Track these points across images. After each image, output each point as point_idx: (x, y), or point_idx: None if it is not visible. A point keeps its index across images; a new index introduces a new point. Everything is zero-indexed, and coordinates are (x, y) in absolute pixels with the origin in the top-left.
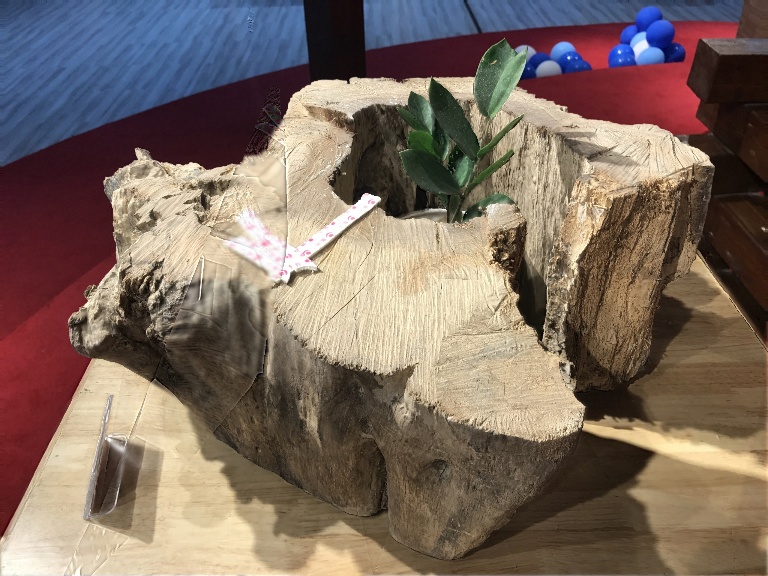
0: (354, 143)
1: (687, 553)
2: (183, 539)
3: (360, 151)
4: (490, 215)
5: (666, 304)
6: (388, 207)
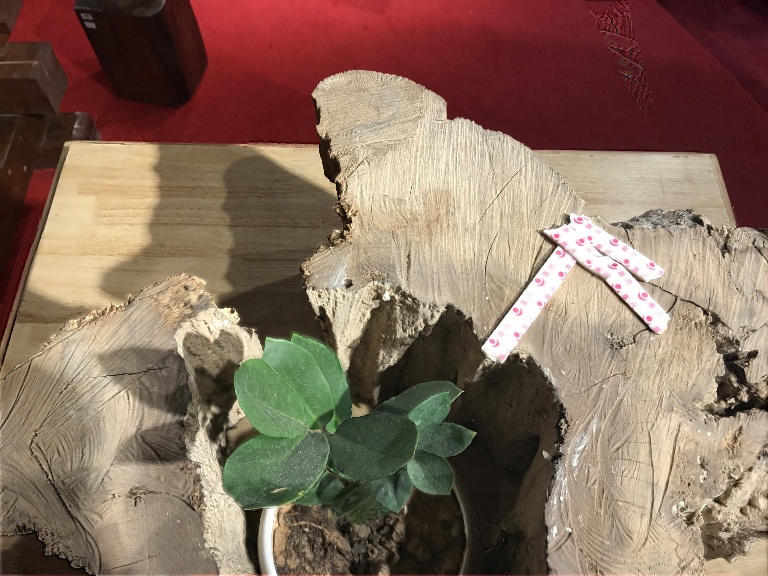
0: (545, 574)
1: (212, 240)
2: None
3: None
4: (344, 266)
5: (42, 561)
6: None
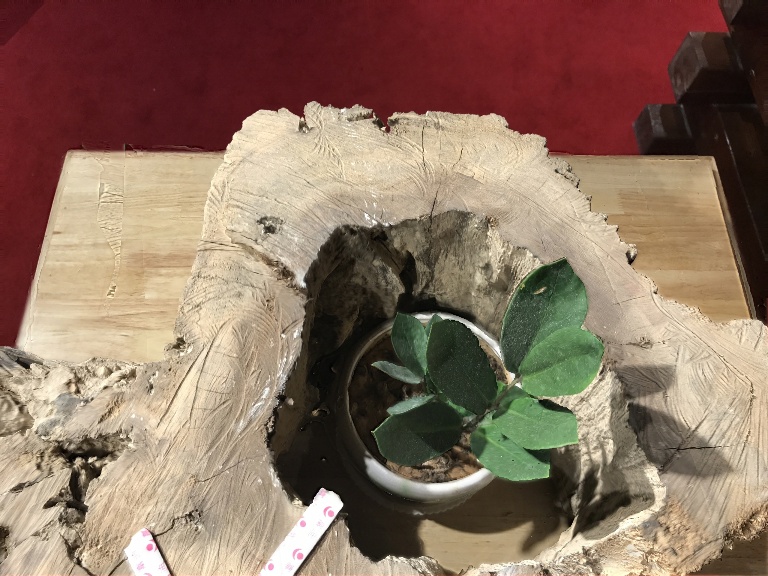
0: (307, 309)
1: None
2: None
3: (317, 292)
4: None
5: None
6: (358, 316)
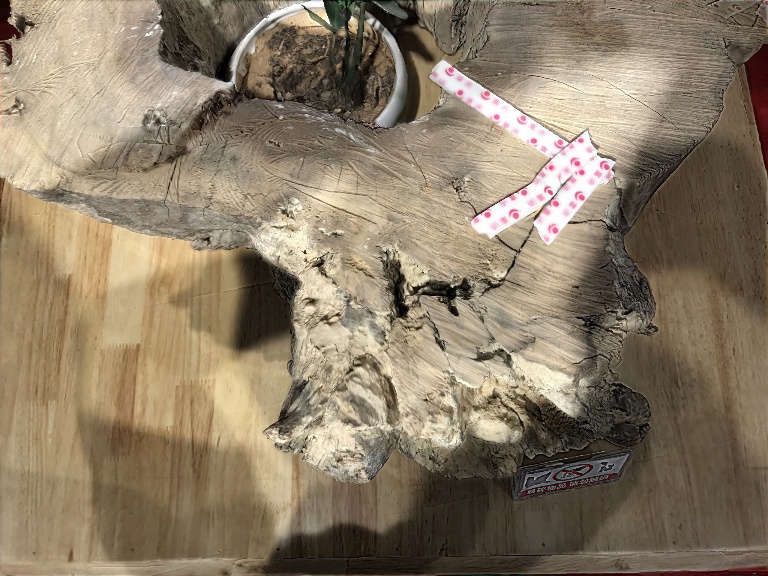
0: None
1: None
2: (630, 373)
3: None
4: None
5: None
6: None
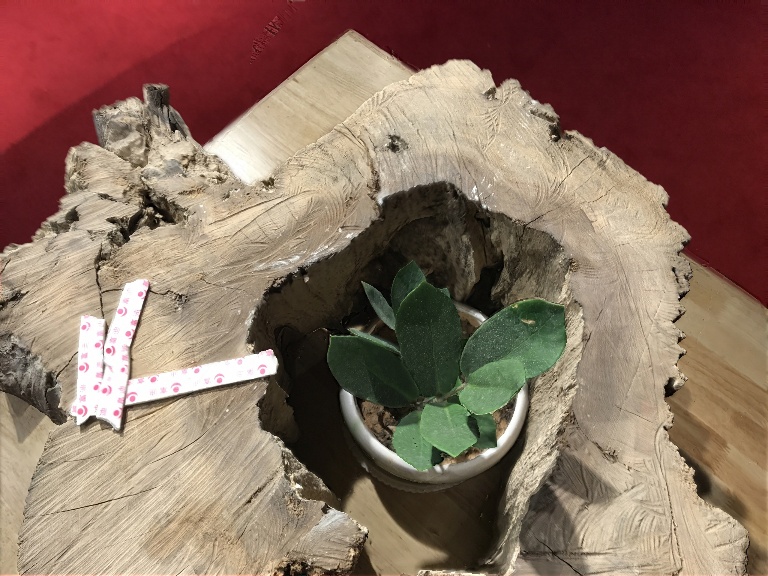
0: (375, 226)
1: None
2: None
3: (399, 224)
4: (317, 528)
5: None
6: (431, 278)
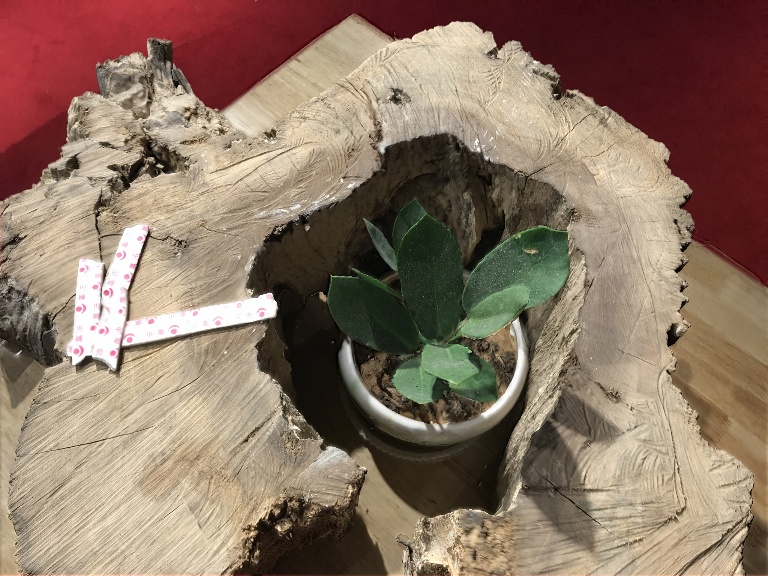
0: (377, 178)
1: None
2: None
3: (400, 180)
4: (315, 465)
5: None
6: None
